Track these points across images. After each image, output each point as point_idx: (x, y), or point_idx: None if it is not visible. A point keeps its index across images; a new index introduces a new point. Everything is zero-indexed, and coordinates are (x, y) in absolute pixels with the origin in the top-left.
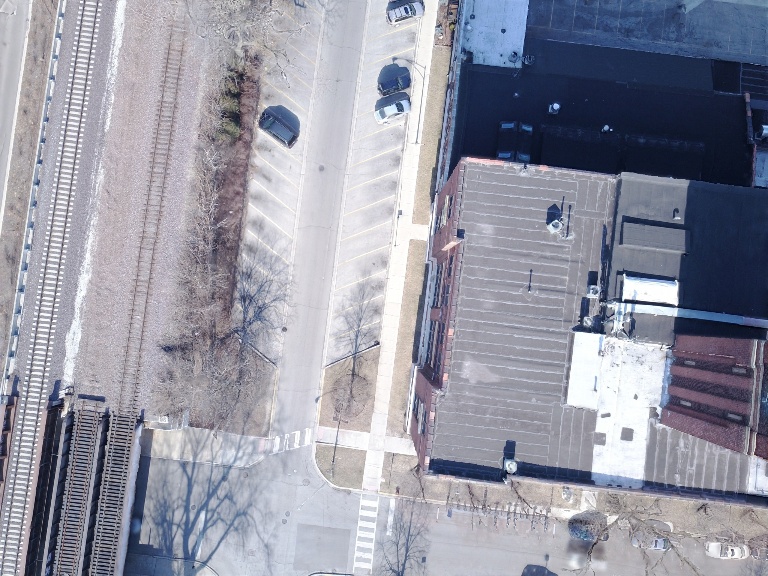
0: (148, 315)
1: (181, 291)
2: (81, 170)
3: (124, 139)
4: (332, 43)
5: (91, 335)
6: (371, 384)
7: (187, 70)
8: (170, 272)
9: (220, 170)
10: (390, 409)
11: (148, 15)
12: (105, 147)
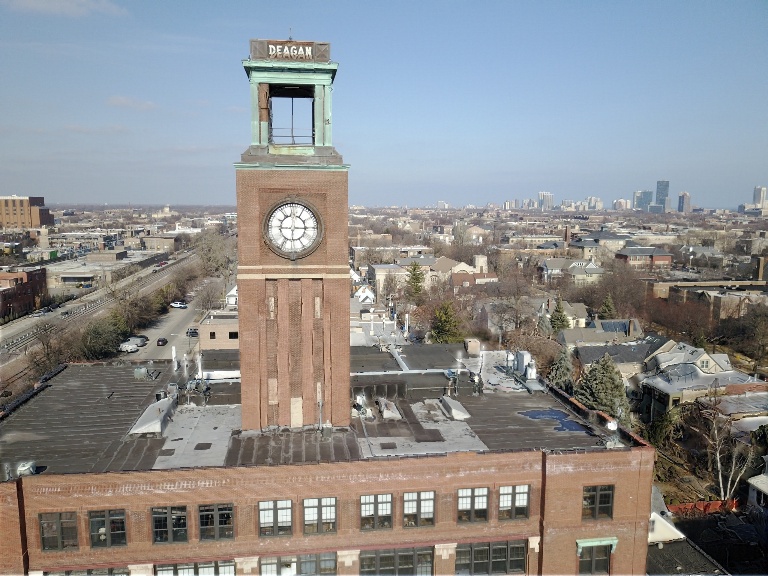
0: None
1: None
2: None
3: None
4: None
5: None
6: None
7: None
8: None
9: None
10: None
11: None
12: None
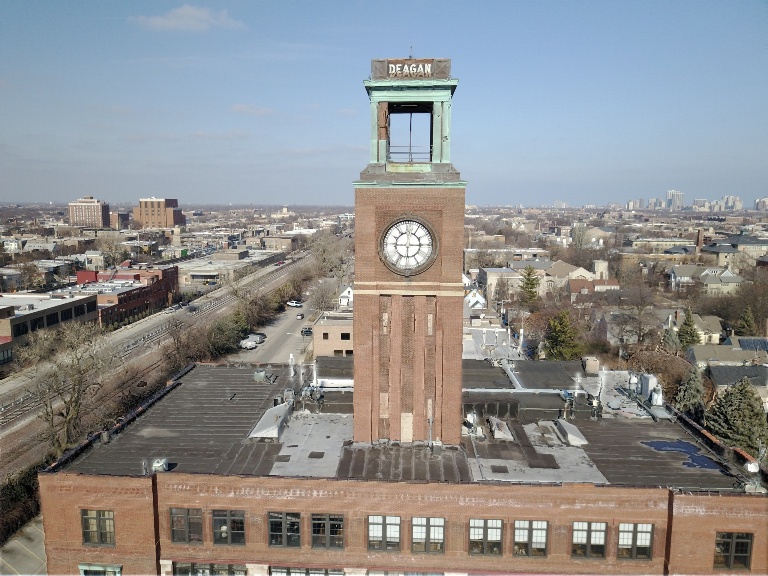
0: None
1: None
2: None
3: None
4: None
5: None
6: None
7: (7, 468)
8: None
9: None
10: None
11: None
12: None
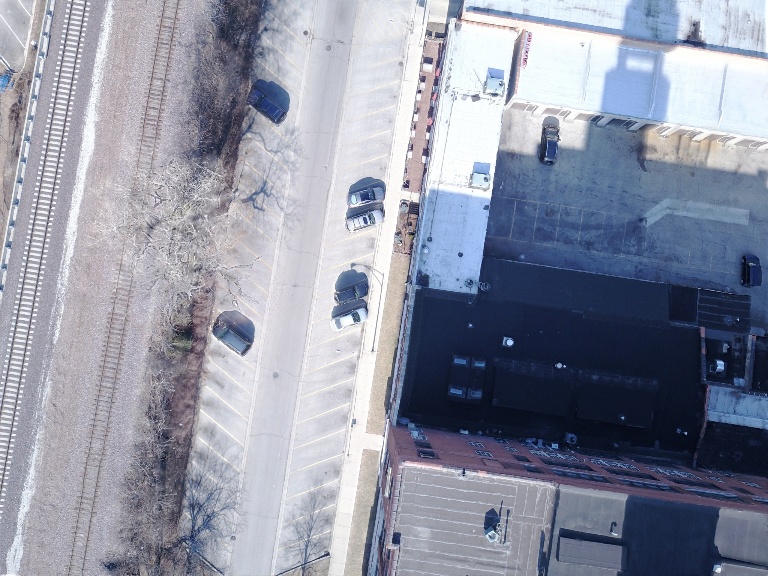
0: (92, 534)
1: (125, 517)
2: (27, 384)
3: (73, 351)
4: (290, 247)
5: (33, 552)
6: None
7: None
8: (116, 488)
9: None
10: None
11: (101, 225)
12: (53, 359)
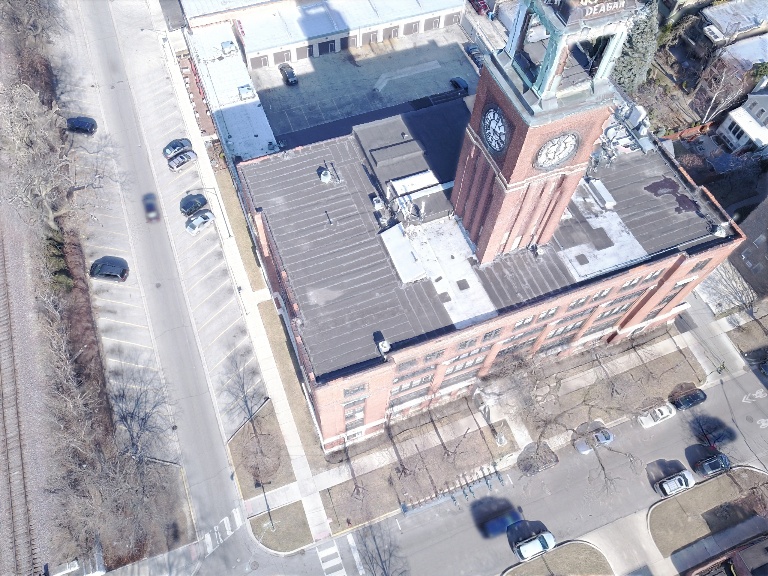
0: (26, 465)
1: (53, 420)
2: None
3: None
4: (133, 201)
5: None
6: (277, 436)
7: (11, 256)
8: (39, 418)
9: (64, 315)
10: (305, 449)
11: None
12: None
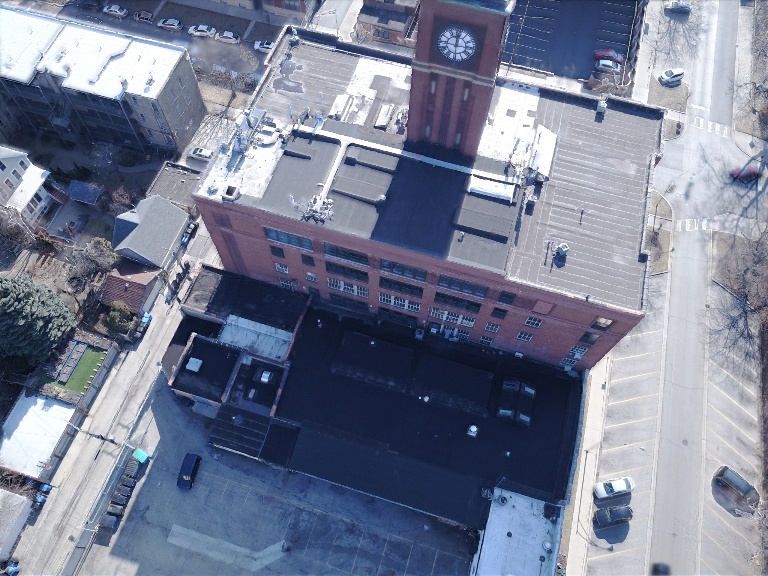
0: None
1: None
2: None
3: None
4: None
5: None
6: None
7: None
8: None
9: None
10: None
11: None
12: None
